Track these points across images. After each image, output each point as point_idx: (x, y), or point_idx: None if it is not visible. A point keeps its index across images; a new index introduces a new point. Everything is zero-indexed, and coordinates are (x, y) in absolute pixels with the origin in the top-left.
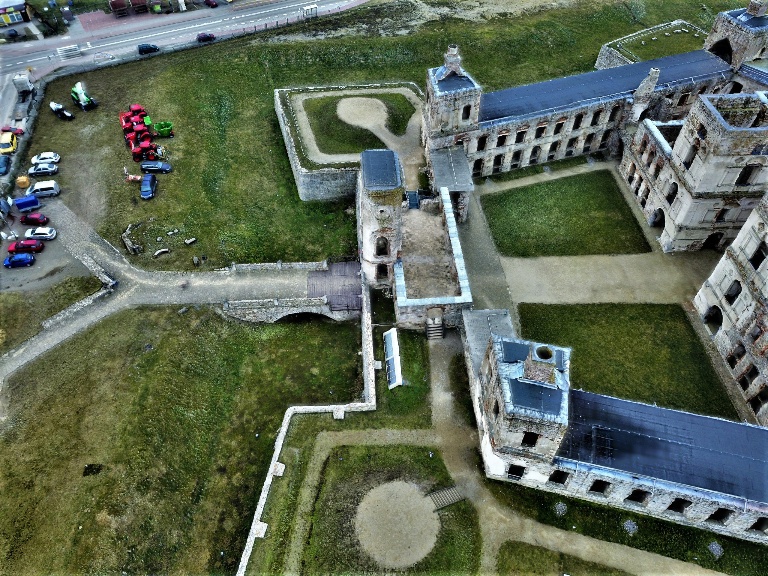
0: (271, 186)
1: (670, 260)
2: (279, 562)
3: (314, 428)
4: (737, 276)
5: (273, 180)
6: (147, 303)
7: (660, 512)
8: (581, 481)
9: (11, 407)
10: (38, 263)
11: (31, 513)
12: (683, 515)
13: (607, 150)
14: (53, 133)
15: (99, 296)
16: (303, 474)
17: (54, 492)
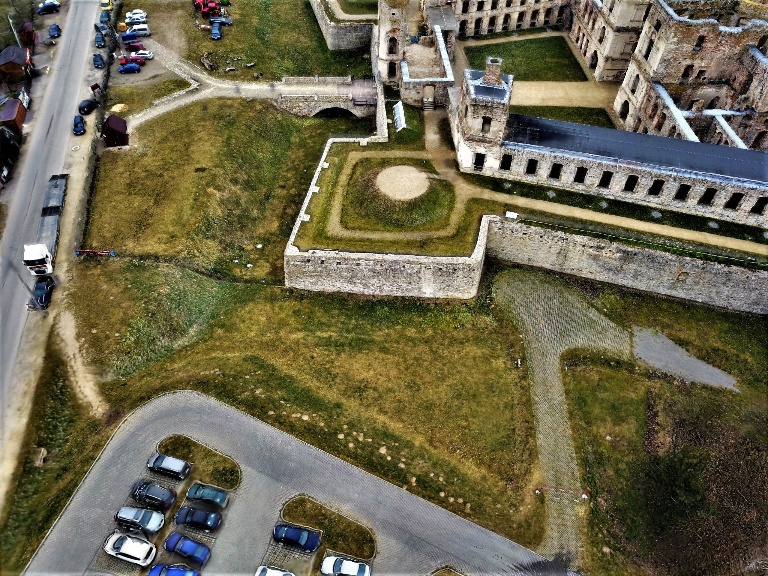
0: (306, 40)
1: (601, 86)
2: (328, 204)
3: (347, 150)
4: (637, 71)
5: (307, 37)
6: (224, 96)
7: (570, 184)
8: (520, 161)
9: (140, 141)
10: (143, 71)
11: (164, 187)
12: (584, 184)
13: (562, 24)
14: (138, 1)
15: (190, 90)
16: (341, 169)
17: (177, 179)
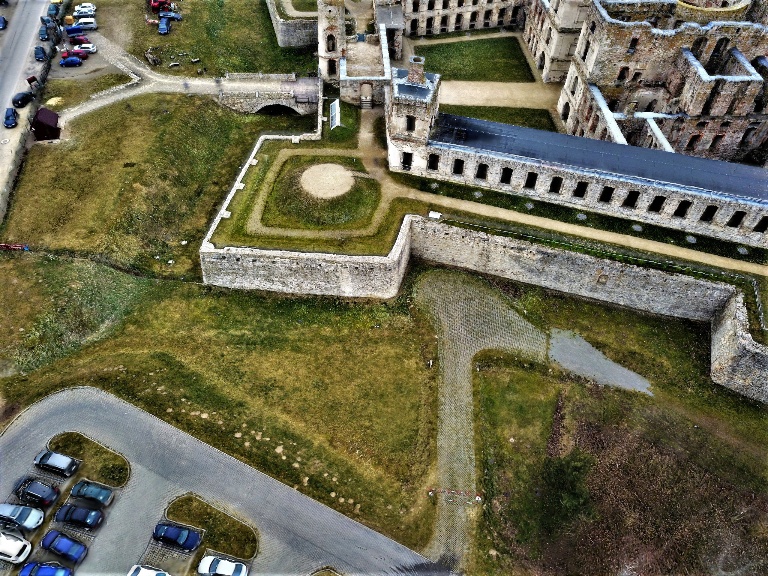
0: (257, 37)
1: (547, 87)
2: (251, 201)
3: (279, 147)
4: (576, 73)
5: (259, 33)
6: (164, 91)
7: (496, 184)
8: (446, 161)
9: (72, 135)
10: (84, 65)
11: (90, 182)
12: (510, 185)
13: (517, 25)
14: None
15: (130, 84)
16: (270, 166)
17: (104, 174)
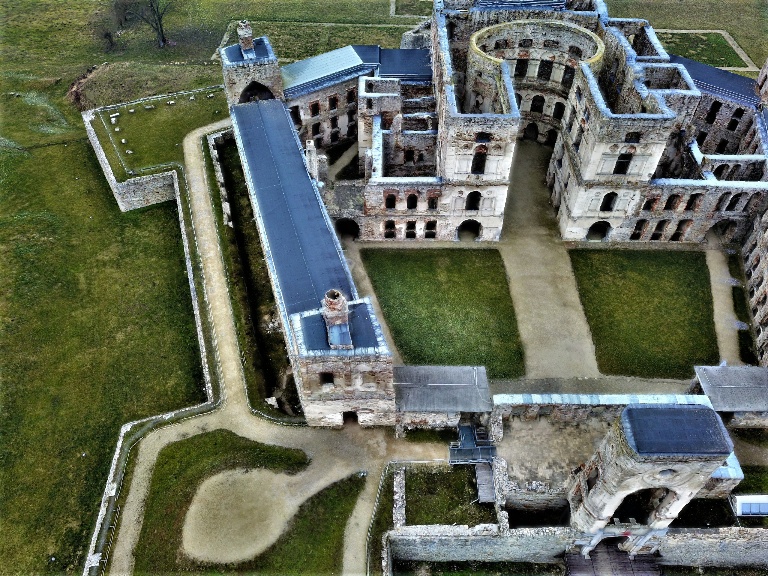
0: None
1: (509, 240)
2: None
3: None
4: (607, 191)
5: None
6: None
7: None
8: None
9: None
10: None
11: None
12: None
13: None
14: None
15: None
16: None
17: None
